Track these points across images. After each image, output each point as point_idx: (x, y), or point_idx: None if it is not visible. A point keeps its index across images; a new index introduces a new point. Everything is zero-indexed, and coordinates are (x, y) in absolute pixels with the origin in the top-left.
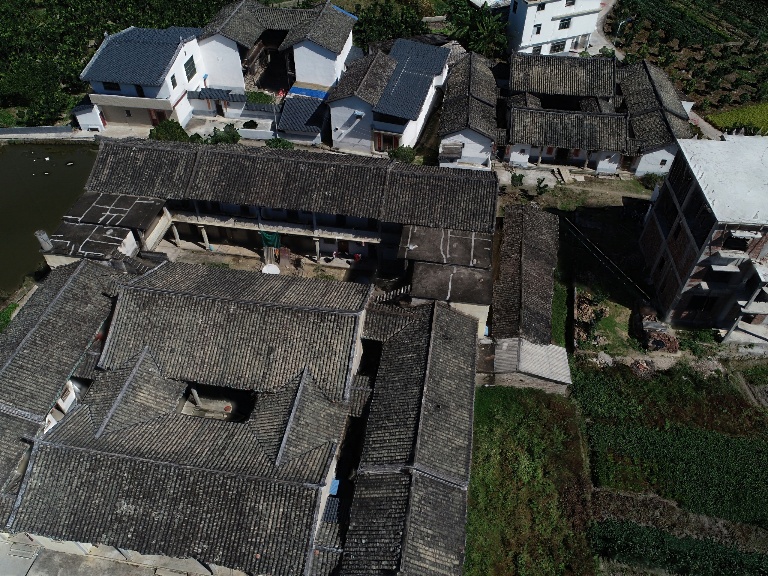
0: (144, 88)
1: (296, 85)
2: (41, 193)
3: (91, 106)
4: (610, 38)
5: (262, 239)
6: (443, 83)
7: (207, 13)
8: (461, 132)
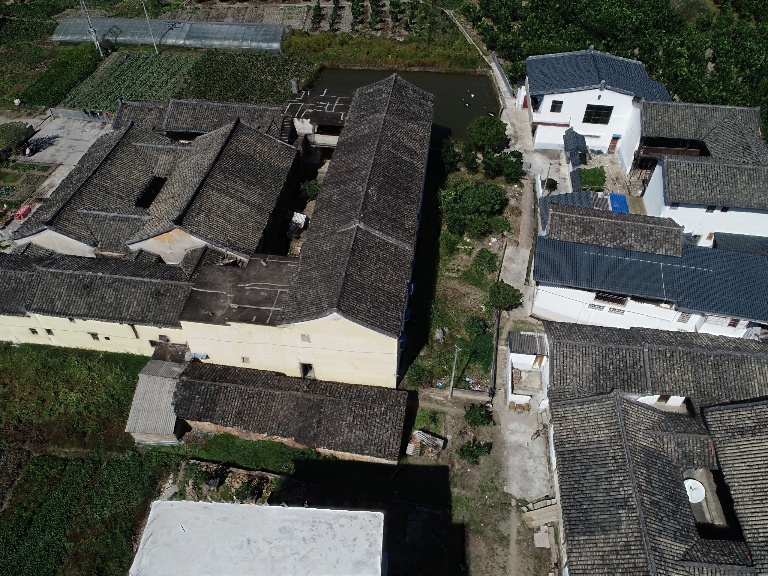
0: None
1: (632, 198)
2: None
3: (521, 84)
4: None
5: None
6: None
7: None
8: None
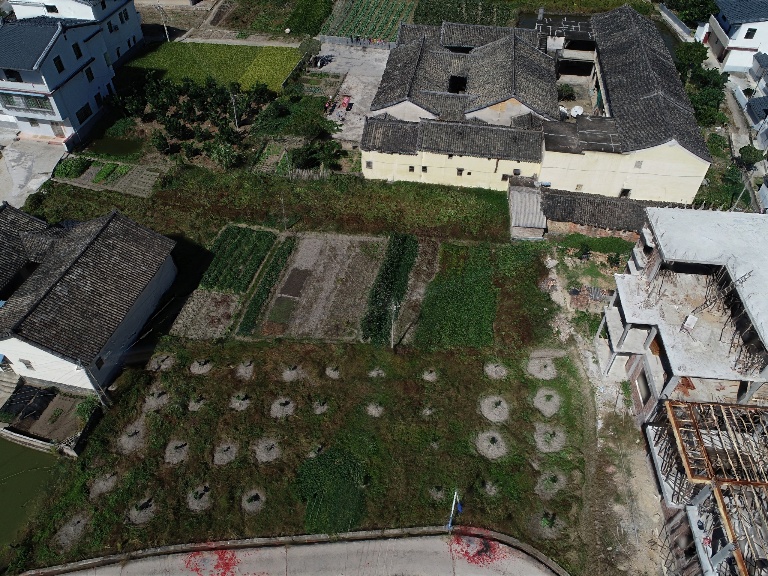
0: None
1: None
2: None
3: (705, 22)
4: None
5: None
6: None
7: None
8: None
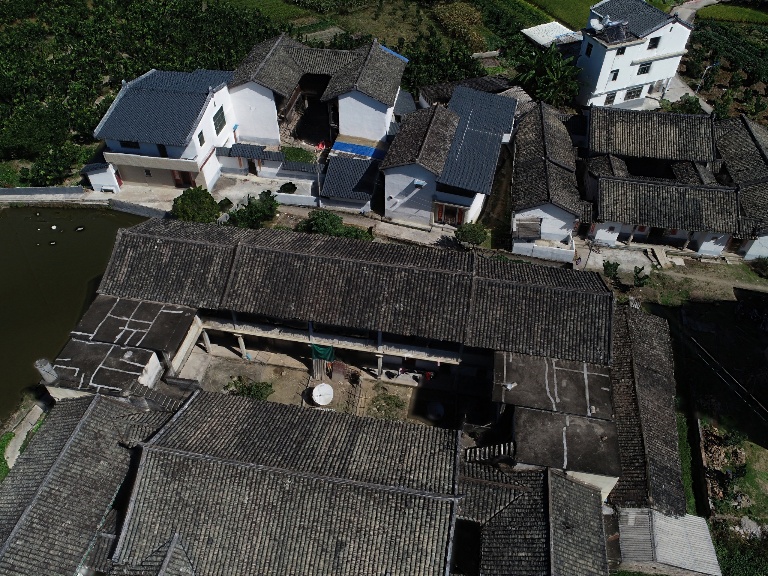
0: (167, 147)
1: (340, 139)
2: (46, 273)
3: (105, 166)
4: (685, 79)
5: (312, 352)
6: (509, 139)
7: (234, 46)
8: (540, 207)
